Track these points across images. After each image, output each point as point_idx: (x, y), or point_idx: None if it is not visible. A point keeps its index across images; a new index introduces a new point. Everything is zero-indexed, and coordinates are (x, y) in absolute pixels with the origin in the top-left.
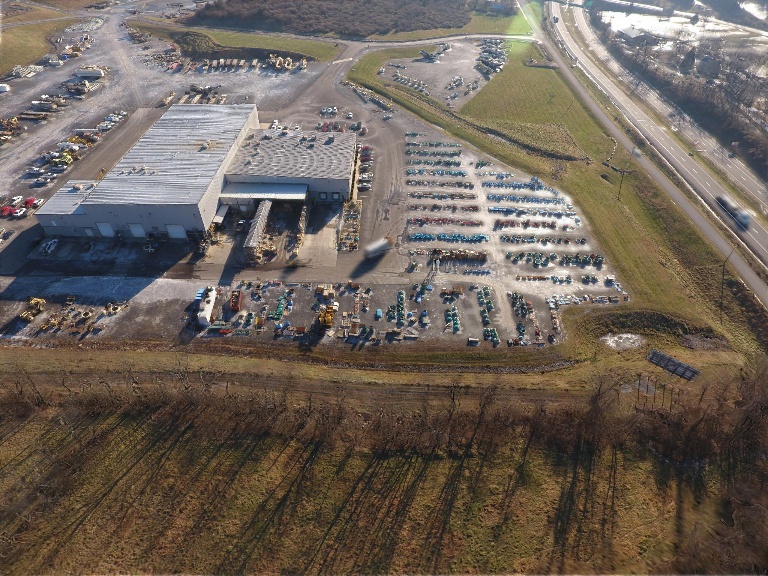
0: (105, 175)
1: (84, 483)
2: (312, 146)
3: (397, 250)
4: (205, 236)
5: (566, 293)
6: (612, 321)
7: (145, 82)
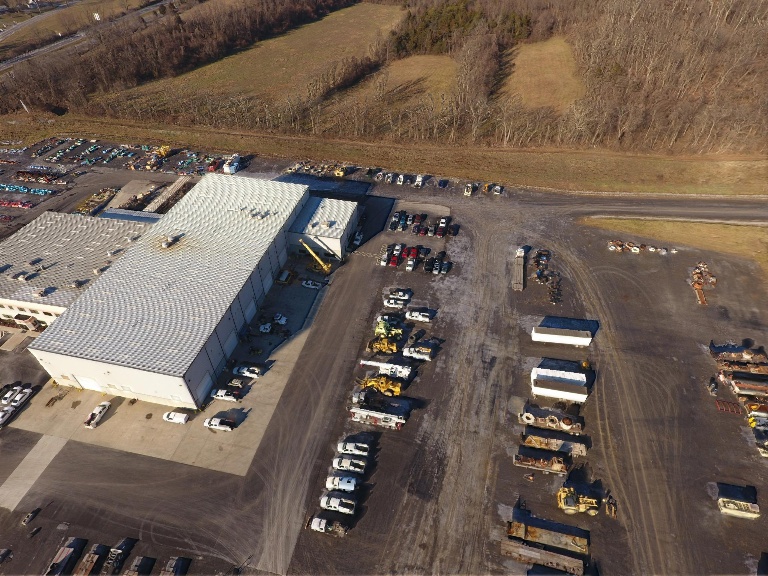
0: (323, 301)
1: None
2: None
3: (75, 185)
4: None
5: (4, 153)
6: (2, 145)
7: None
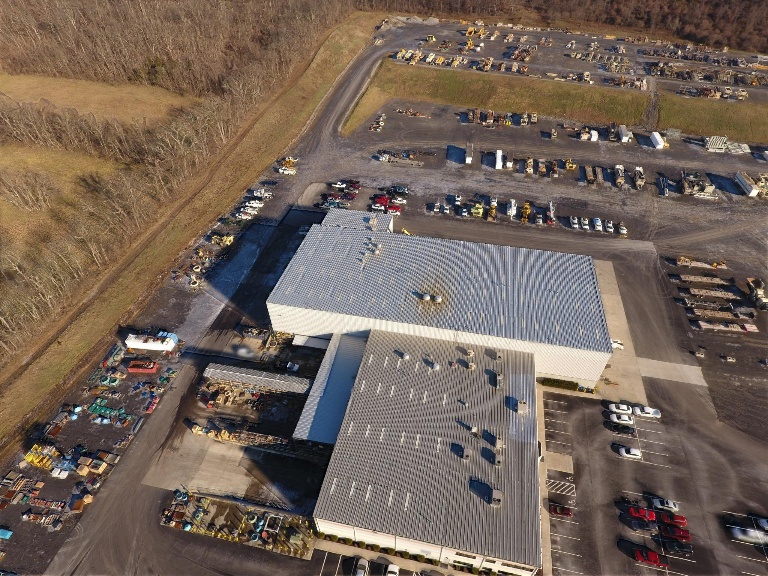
0: None
1: (5, 291)
2: (462, 454)
3: None
4: (272, 331)
5: None
6: None
7: (761, 235)
